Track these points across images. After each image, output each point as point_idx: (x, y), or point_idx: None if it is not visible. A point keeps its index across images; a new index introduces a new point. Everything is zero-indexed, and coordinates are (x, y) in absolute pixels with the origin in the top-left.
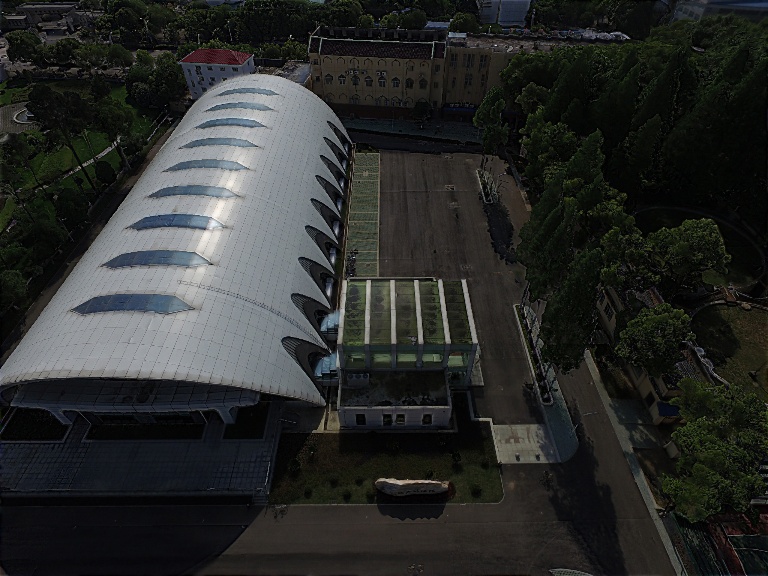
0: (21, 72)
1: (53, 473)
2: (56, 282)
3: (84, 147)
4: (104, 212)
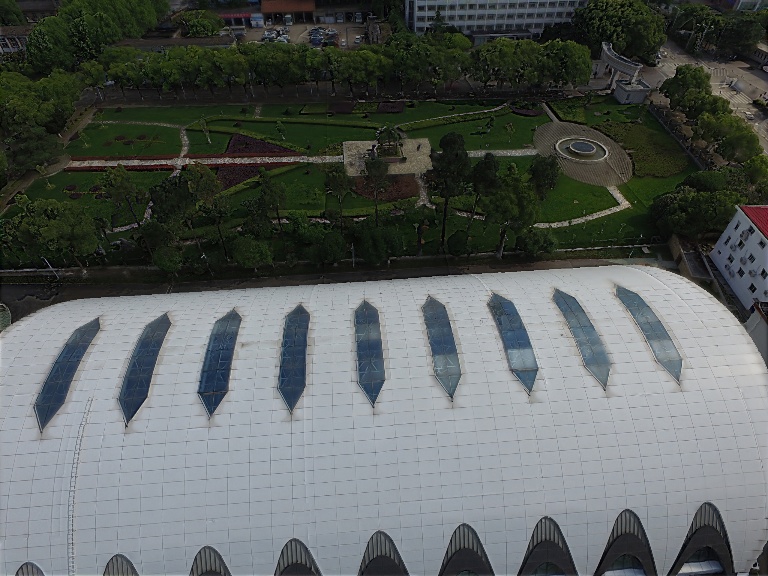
0: None
1: None
2: (294, 280)
3: None
4: (411, 270)
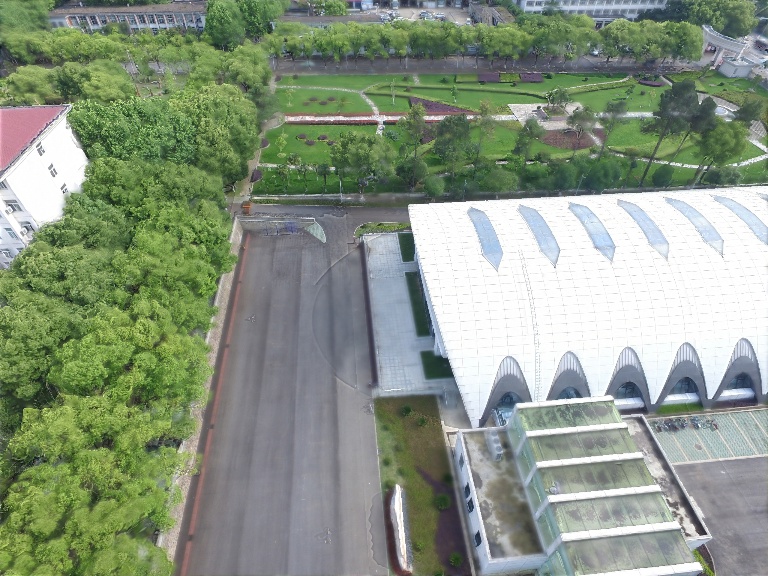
0: (756, 77)
1: (381, 267)
2: None
3: None
4: None
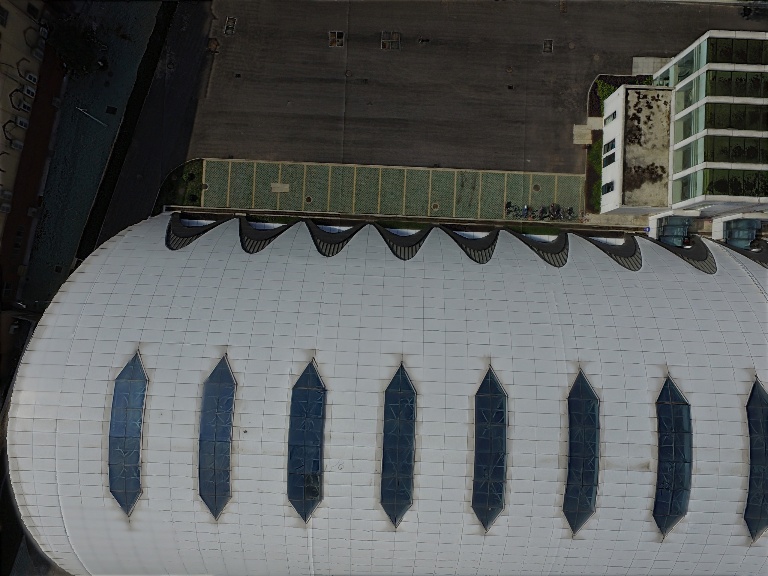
0: None
1: None
2: None
3: None
4: None
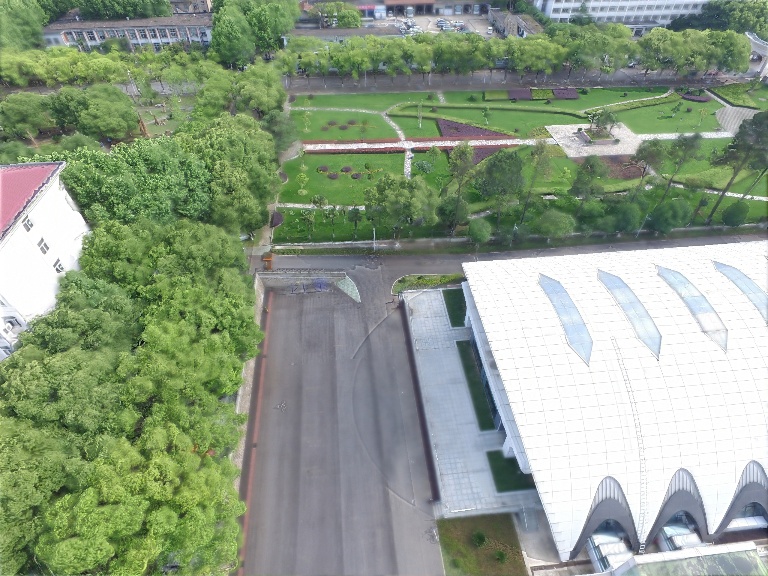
0: None
1: (428, 335)
2: (587, 250)
3: (760, 182)
4: (688, 239)
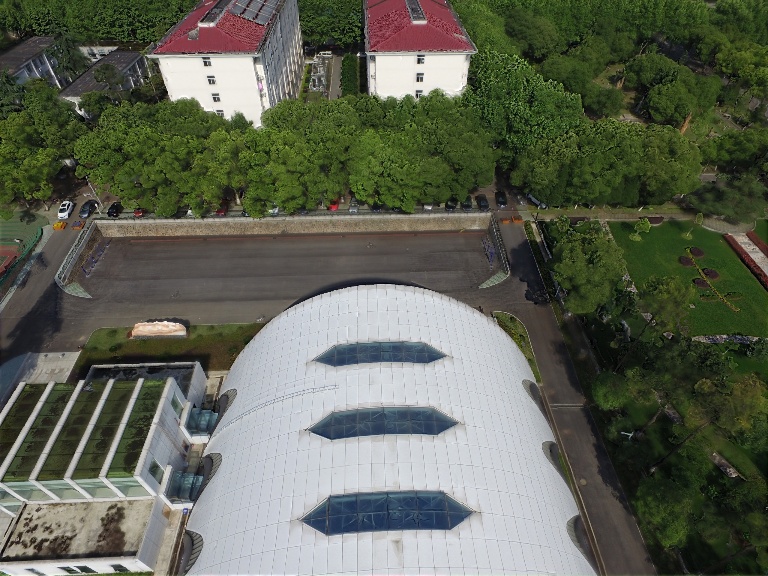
0: None
1: None
2: None
3: None
4: None
